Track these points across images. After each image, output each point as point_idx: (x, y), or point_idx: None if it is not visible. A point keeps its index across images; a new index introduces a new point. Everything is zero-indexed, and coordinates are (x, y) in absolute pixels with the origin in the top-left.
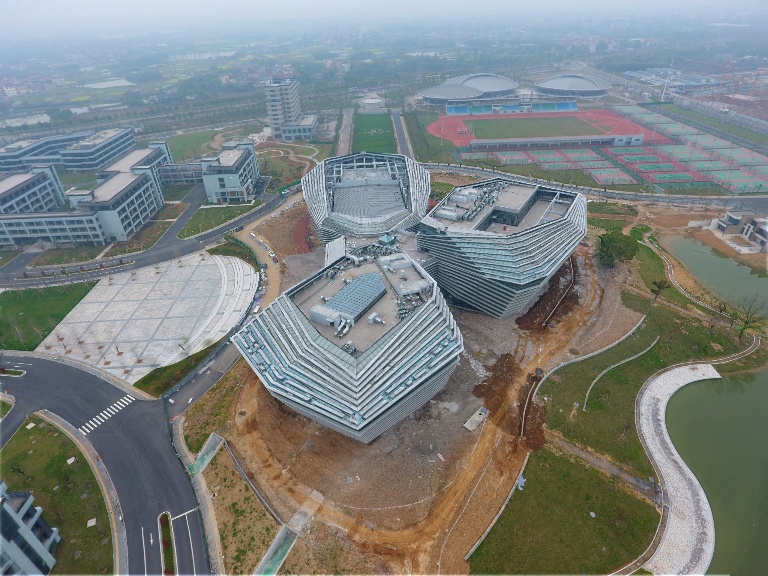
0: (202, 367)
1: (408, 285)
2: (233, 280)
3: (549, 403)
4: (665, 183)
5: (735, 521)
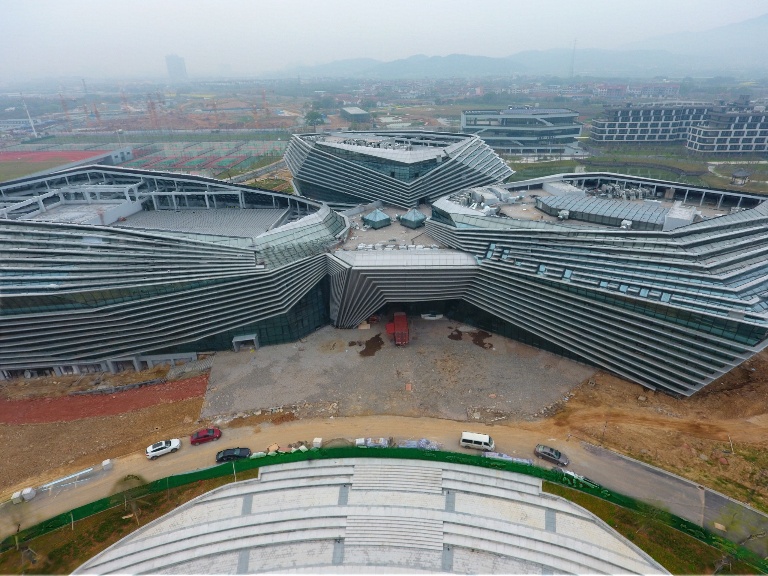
0: (714, 544)
1: (562, 189)
2: (245, 556)
3: None
4: (236, 165)
5: None
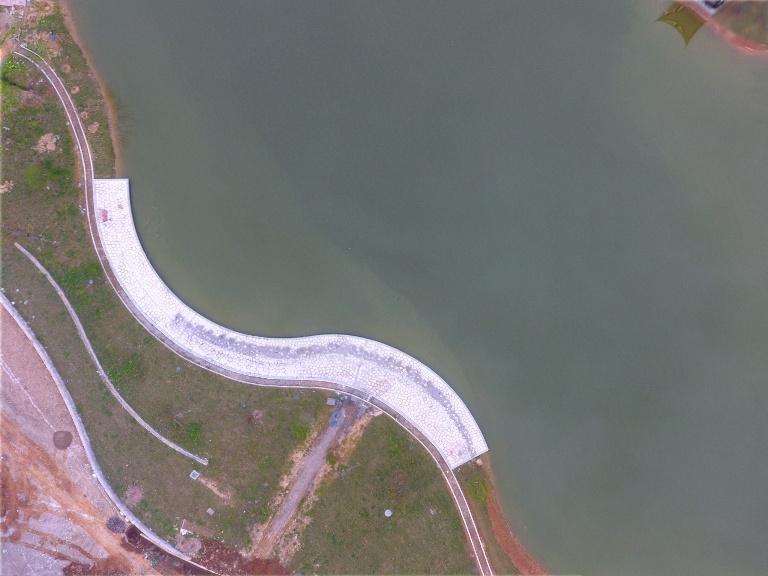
0: None
1: None
2: None
3: (194, 529)
4: None
5: (391, 318)
